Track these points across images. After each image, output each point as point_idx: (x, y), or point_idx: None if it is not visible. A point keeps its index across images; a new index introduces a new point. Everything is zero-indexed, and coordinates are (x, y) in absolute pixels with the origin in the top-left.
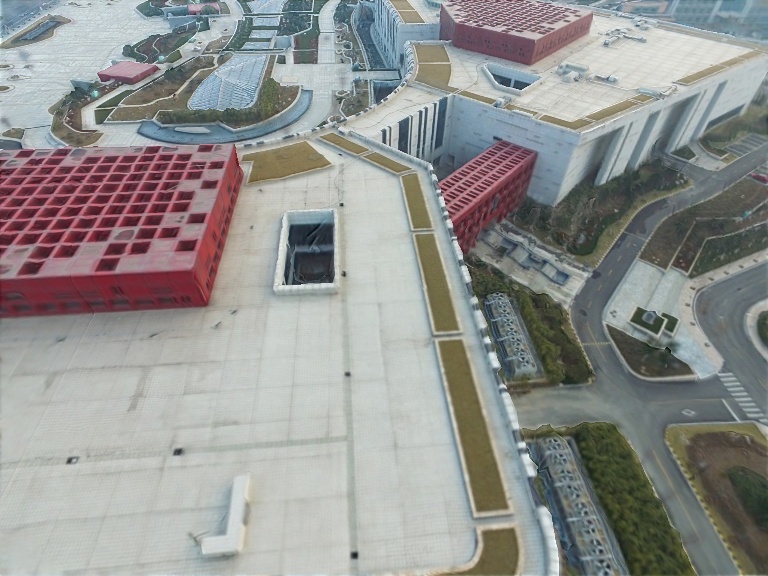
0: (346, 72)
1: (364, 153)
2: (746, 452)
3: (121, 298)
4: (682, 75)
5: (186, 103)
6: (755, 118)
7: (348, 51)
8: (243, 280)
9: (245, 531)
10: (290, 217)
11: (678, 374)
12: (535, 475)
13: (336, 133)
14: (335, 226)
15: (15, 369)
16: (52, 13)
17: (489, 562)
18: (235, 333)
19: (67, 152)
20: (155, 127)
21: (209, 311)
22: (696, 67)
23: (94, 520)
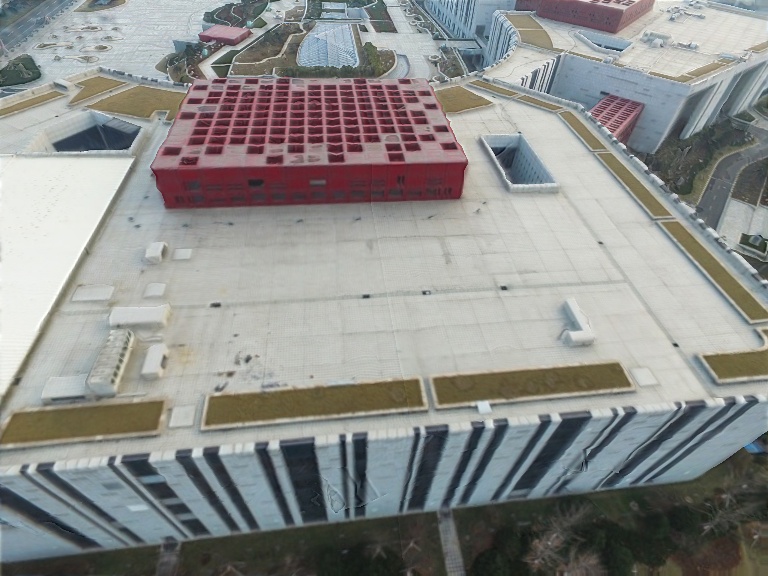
0: (428, 40)
1: (515, 96)
2: None
3: (398, 188)
4: (750, 45)
5: (295, 62)
6: None
7: (423, 22)
8: (476, 182)
9: (591, 331)
10: None
11: None
12: None
13: (481, 80)
14: (530, 146)
15: (336, 237)
16: None
17: None
18: (495, 216)
19: (287, 81)
20: None
21: (464, 202)
22: (758, 39)
23: (472, 326)
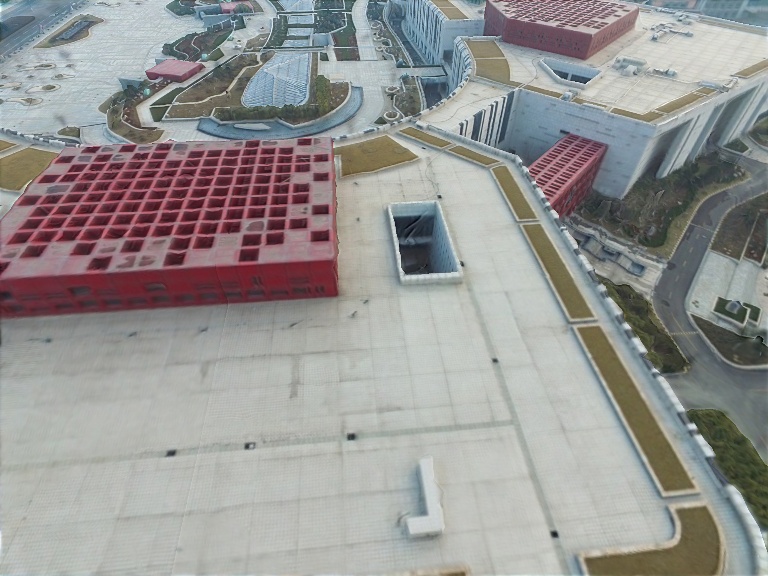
0: (391, 69)
1: (448, 146)
2: None
3: (257, 288)
4: (738, 68)
5: (240, 100)
6: None
7: (389, 48)
8: (365, 270)
9: (443, 512)
10: (393, 209)
11: None
12: (714, 455)
13: (414, 127)
14: (443, 217)
15: (167, 358)
16: (83, 13)
17: (691, 539)
18: (373, 322)
19: (169, 146)
20: (214, 124)
21: (341, 301)
22: (750, 60)
23: (290, 503)
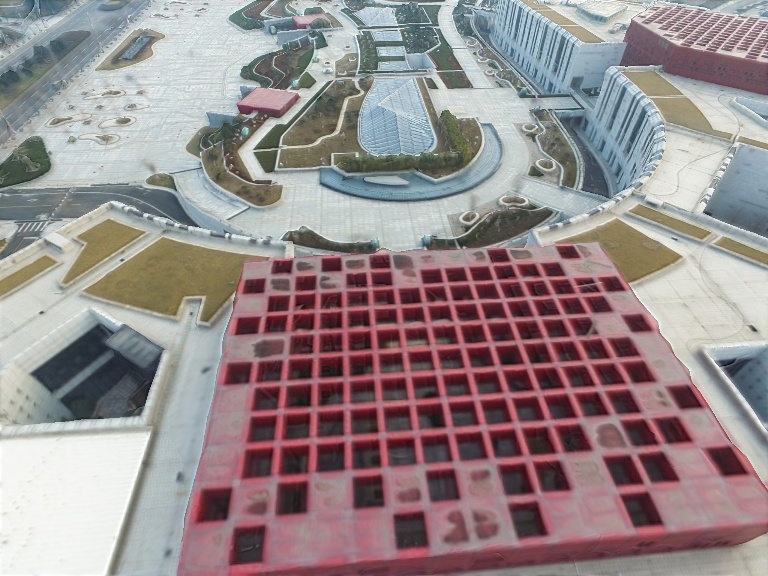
0: (514, 99)
1: (709, 238)
2: None
3: None
4: None
5: (357, 143)
6: None
7: None
8: None
9: None
10: None
11: None
12: None
13: (644, 205)
14: None
15: None
16: (141, 26)
17: None
18: None
19: (386, 260)
20: (338, 176)
21: (748, 557)
22: None
23: None
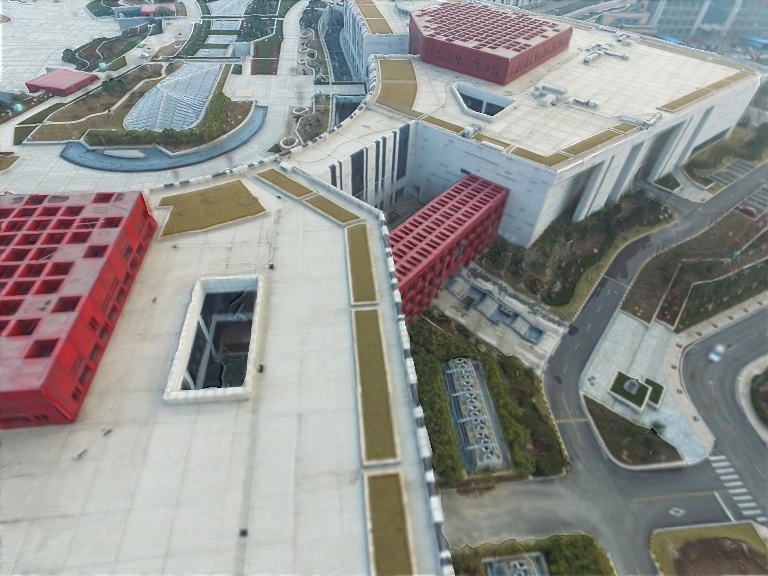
0: (307, 85)
1: (306, 196)
2: (743, 566)
3: None
4: (667, 100)
5: (122, 120)
6: (741, 142)
7: (311, 61)
8: (129, 381)
9: None
10: (204, 285)
11: (664, 461)
12: None
13: (277, 169)
14: (257, 300)
15: None
16: None
17: None
18: (103, 467)
19: None
20: (82, 149)
21: (75, 431)
22: (681, 90)
23: None
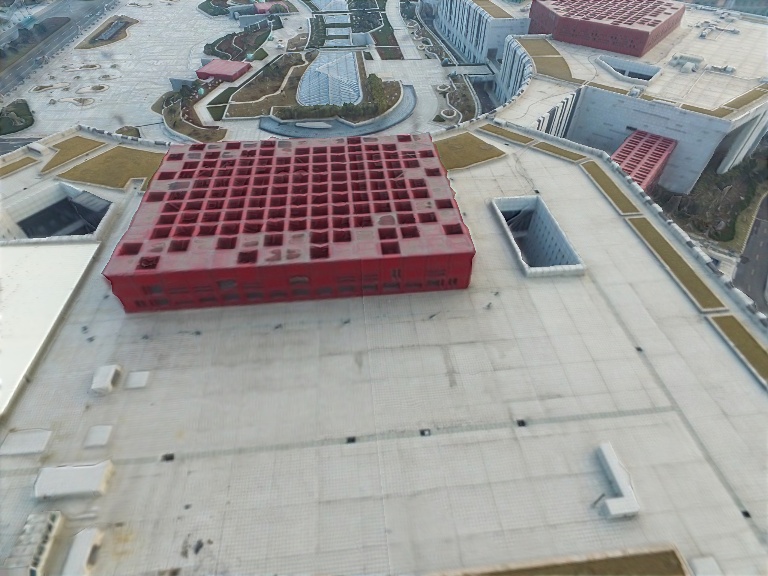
0: (437, 67)
1: (531, 143)
2: None
3: (393, 281)
4: None
5: (295, 99)
6: None
7: (432, 47)
8: (487, 264)
9: (634, 493)
10: (496, 204)
11: None
12: None
13: (492, 124)
14: (549, 211)
15: (319, 349)
16: (117, 14)
17: None
18: (509, 313)
19: (273, 144)
20: (274, 123)
21: (472, 293)
22: None
23: (482, 486)
